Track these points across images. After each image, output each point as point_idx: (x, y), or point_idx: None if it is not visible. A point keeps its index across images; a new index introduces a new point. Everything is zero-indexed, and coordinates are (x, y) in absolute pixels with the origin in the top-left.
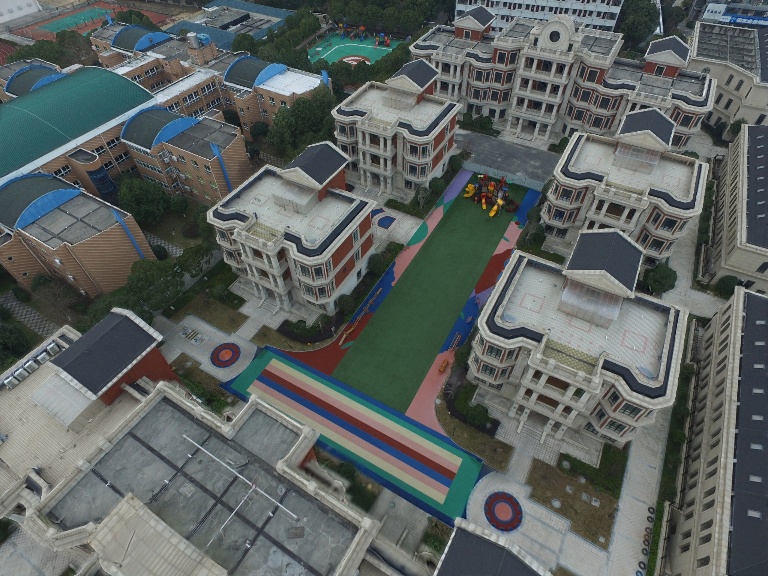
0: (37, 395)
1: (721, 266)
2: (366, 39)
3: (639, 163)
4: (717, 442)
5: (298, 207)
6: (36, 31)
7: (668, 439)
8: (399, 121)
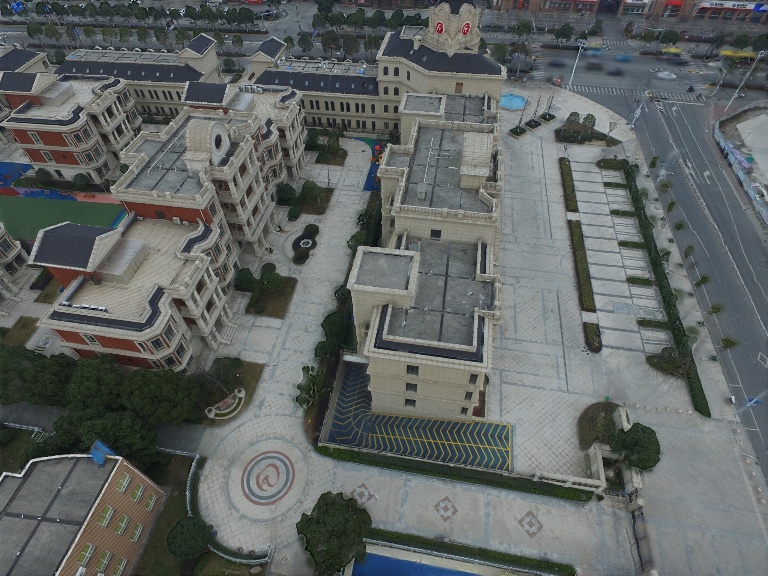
0: (118, 271)
1: None
2: None
3: None
4: (141, 92)
5: None
6: None
7: None
8: None
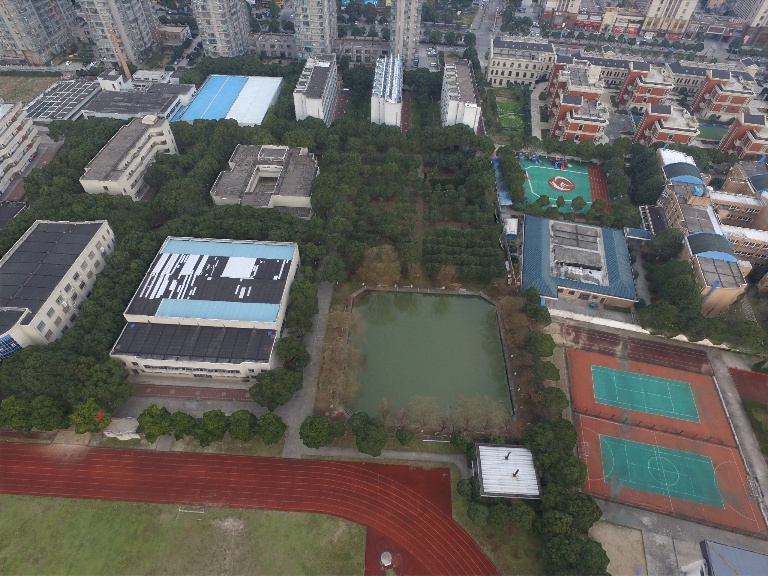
0: None
1: None
2: None
3: None
4: None
5: None
6: (732, 492)
7: None
8: None
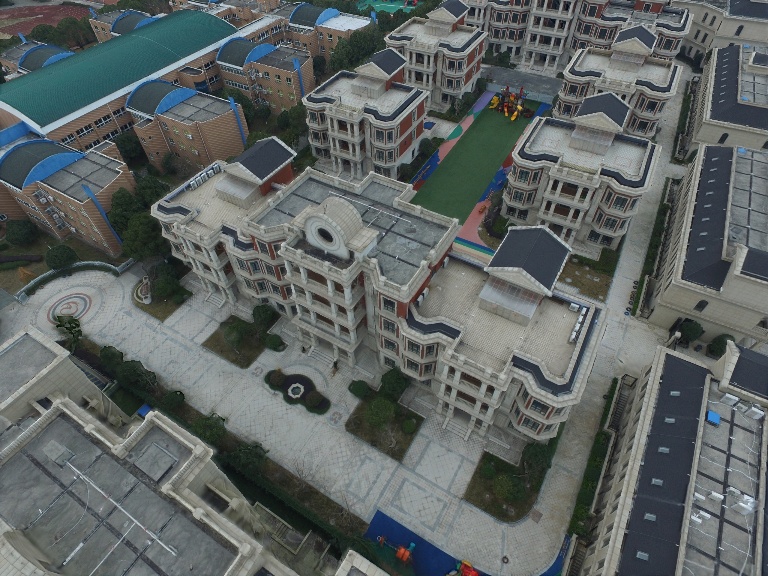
0: (218, 186)
1: (692, 142)
2: (396, 1)
3: (629, 64)
4: None
5: (372, 93)
6: None
7: (649, 246)
8: (440, 42)
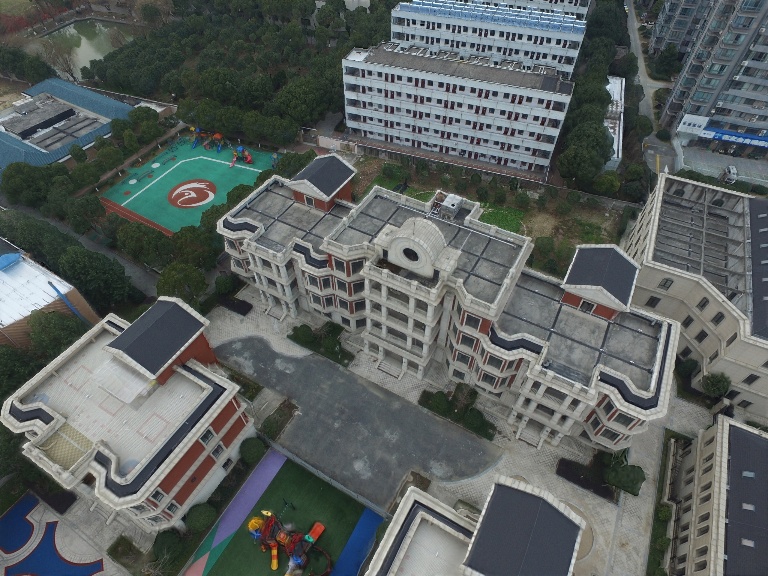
0: None
1: None
2: (225, 149)
3: None
4: None
5: None
6: None
7: None
8: (97, 449)
